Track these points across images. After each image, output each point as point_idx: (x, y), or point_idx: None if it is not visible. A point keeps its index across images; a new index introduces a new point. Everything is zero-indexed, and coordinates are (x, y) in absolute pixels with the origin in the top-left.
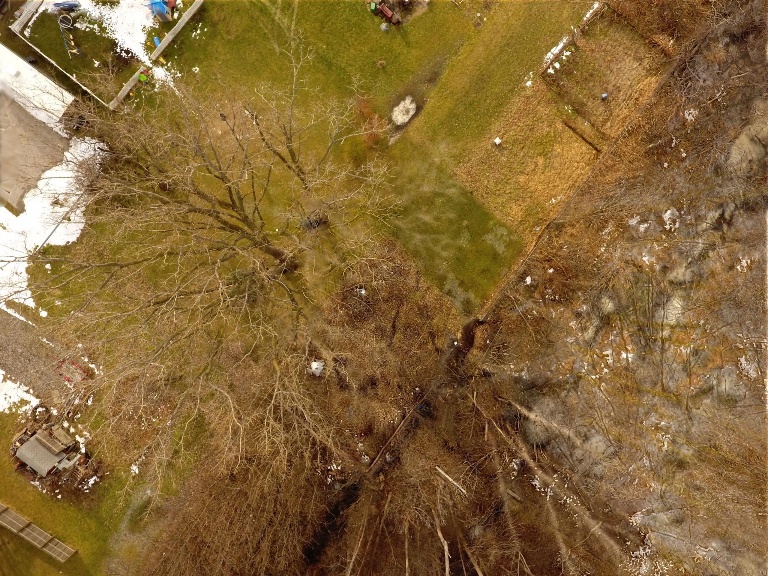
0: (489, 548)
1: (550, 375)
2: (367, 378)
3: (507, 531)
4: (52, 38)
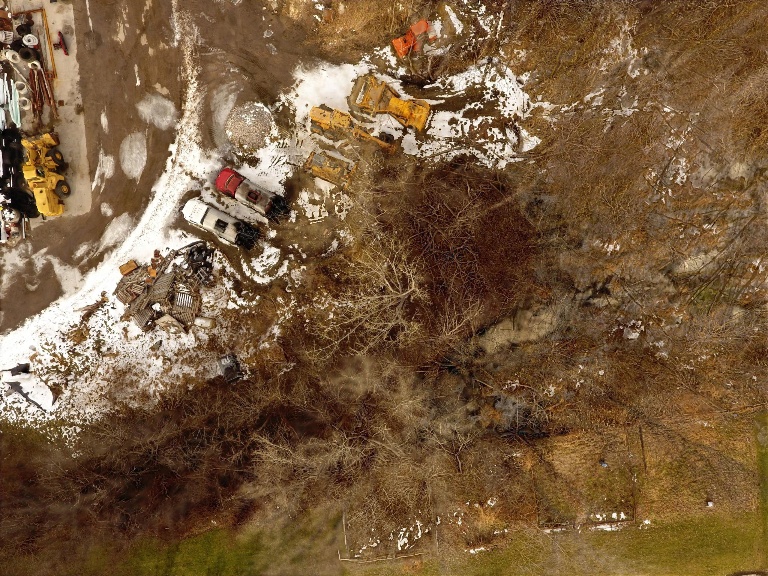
0: None
1: None
2: None
3: None
4: None
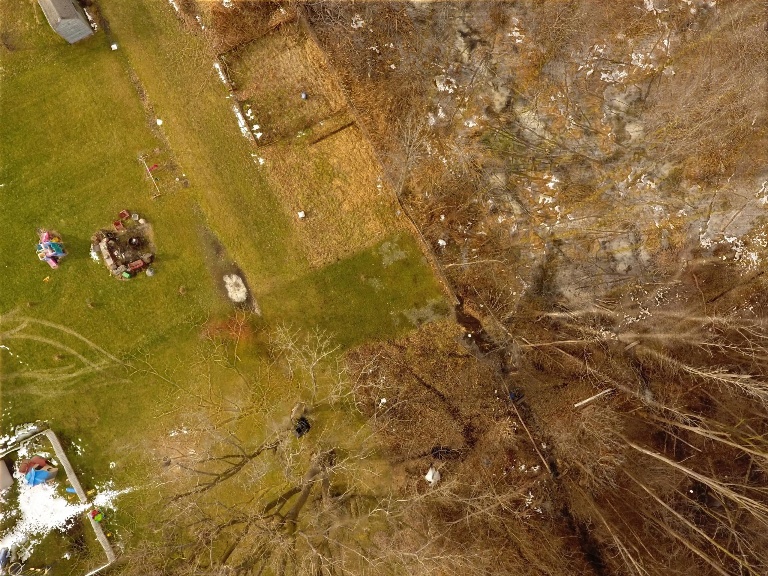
0: (671, 390)
1: (538, 261)
2: (465, 433)
3: (663, 366)
4: None
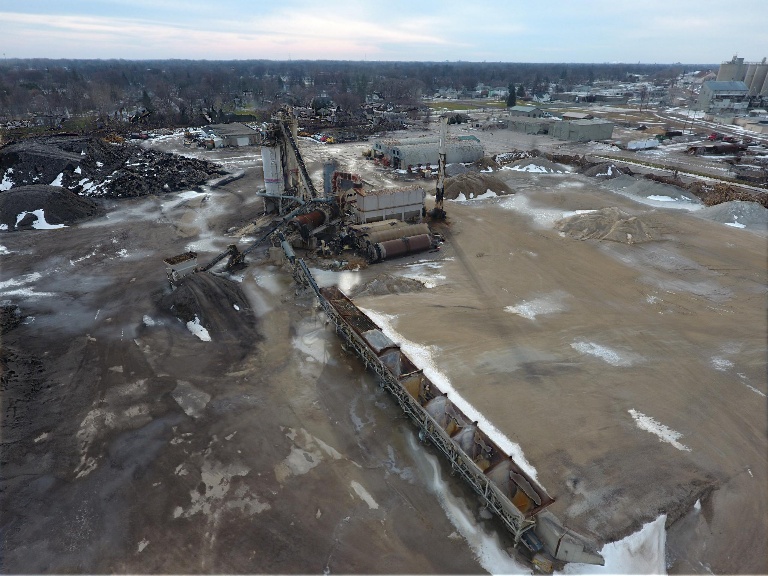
0: None
1: None
2: None
3: None
4: (1, 125)
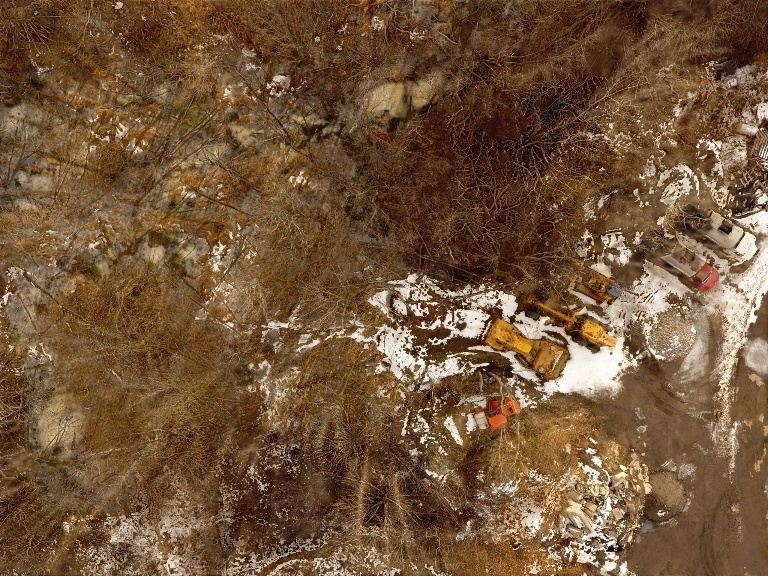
0: None
1: (61, 95)
2: None
3: None
4: None
